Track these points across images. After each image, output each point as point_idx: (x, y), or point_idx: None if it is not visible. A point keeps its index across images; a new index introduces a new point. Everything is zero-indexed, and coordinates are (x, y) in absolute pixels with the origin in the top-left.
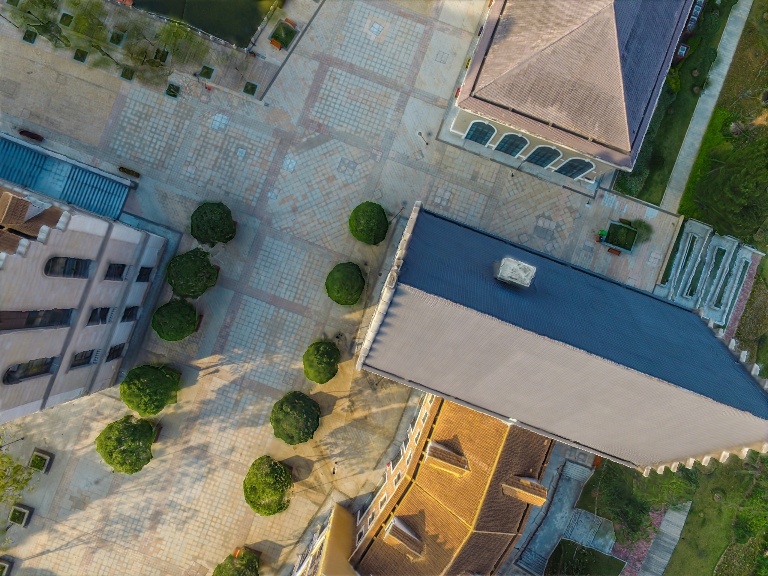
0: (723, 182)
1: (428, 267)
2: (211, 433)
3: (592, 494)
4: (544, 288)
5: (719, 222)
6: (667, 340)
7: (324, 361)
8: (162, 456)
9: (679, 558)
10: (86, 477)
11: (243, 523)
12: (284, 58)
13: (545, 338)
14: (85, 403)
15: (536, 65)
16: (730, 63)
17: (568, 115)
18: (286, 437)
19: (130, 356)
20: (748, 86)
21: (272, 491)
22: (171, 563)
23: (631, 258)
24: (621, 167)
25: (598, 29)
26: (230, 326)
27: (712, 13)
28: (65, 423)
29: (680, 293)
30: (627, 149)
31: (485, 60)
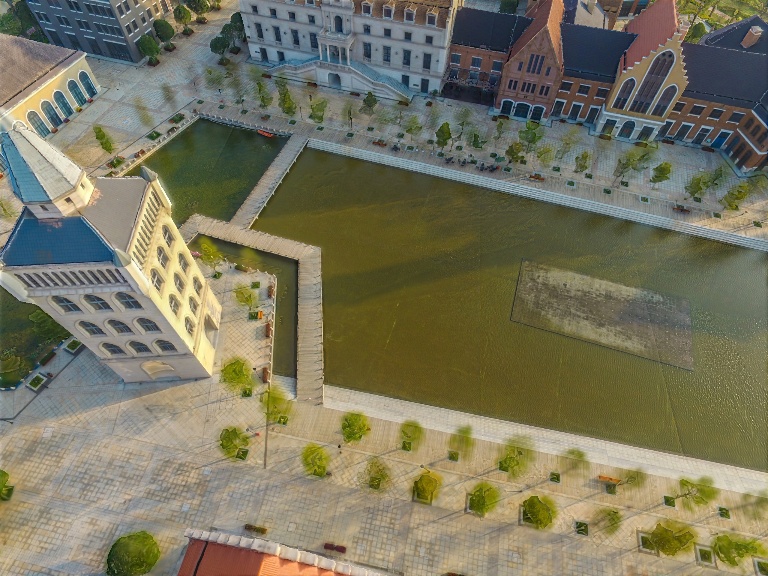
0: None
1: None
2: None
3: None
4: None
5: None
6: None
7: None
8: None
9: None
10: None
11: None
12: (179, 112)
13: None
14: None
15: None
16: None
17: None
18: None
19: None
20: None
21: None
22: None
23: None
24: None
25: None
26: None
27: None
28: None
29: None
30: None
31: None
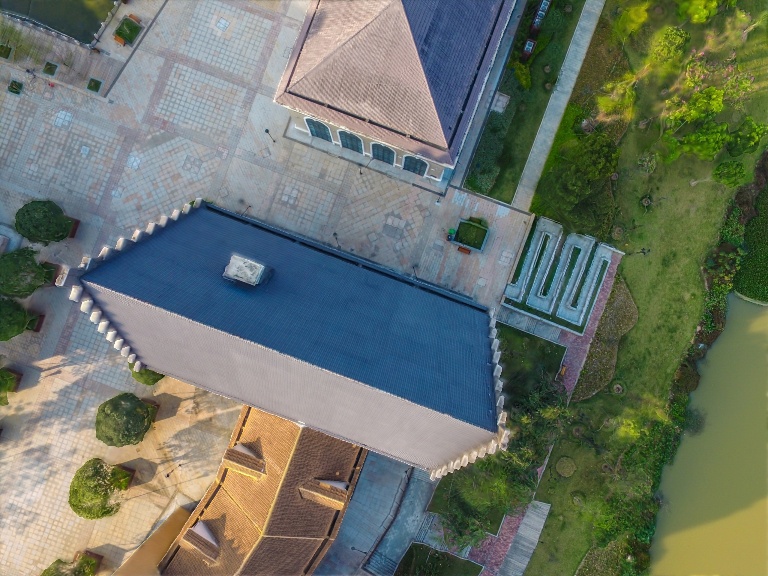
0: (556, 179)
1: (146, 265)
2: (52, 435)
3: (444, 497)
4: (294, 287)
5: (562, 220)
6: (415, 340)
7: None
8: (3, 458)
9: (538, 562)
10: None
11: (85, 527)
12: (129, 54)
13: (236, 338)
14: None
15: (341, 60)
16: (583, 59)
17: (381, 111)
18: (105, 439)
19: None
20: (602, 82)
21: (92, 494)
22: (11, 567)
23: (482, 257)
24: (443, 164)
25: (391, 23)
26: (73, 326)
27: (565, 8)
28: None
29: (535, 293)
30: (444, 146)
31: (300, 55)
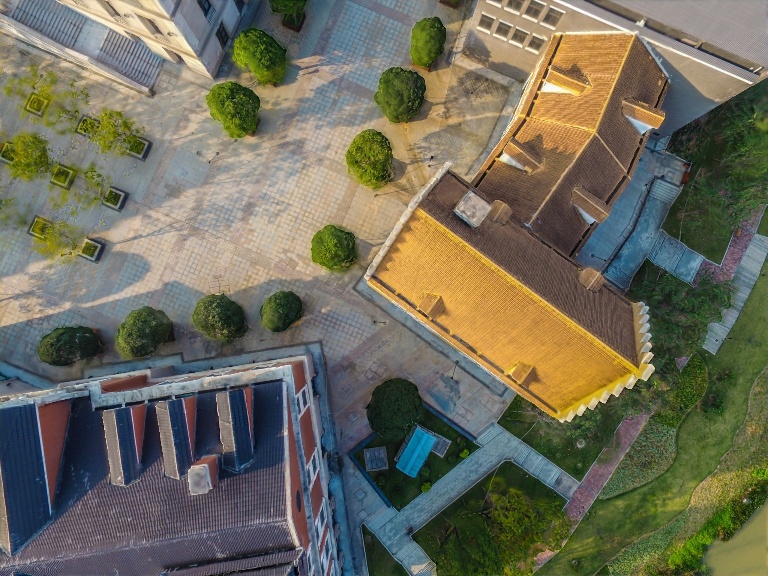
0: None
1: None
2: (308, 130)
3: (678, 216)
4: None
5: None
6: None
7: (436, 26)
8: (258, 150)
9: (759, 294)
10: (182, 166)
11: (335, 220)
12: None
13: None
14: (185, 95)
15: None
16: None
17: None
18: (396, 94)
19: (232, 52)
20: None
21: (379, 147)
22: (261, 255)
23: None
24: None
25: None
26: (331, 29)
27: None
28: (164, 113)
29: None
30: None
31: None
